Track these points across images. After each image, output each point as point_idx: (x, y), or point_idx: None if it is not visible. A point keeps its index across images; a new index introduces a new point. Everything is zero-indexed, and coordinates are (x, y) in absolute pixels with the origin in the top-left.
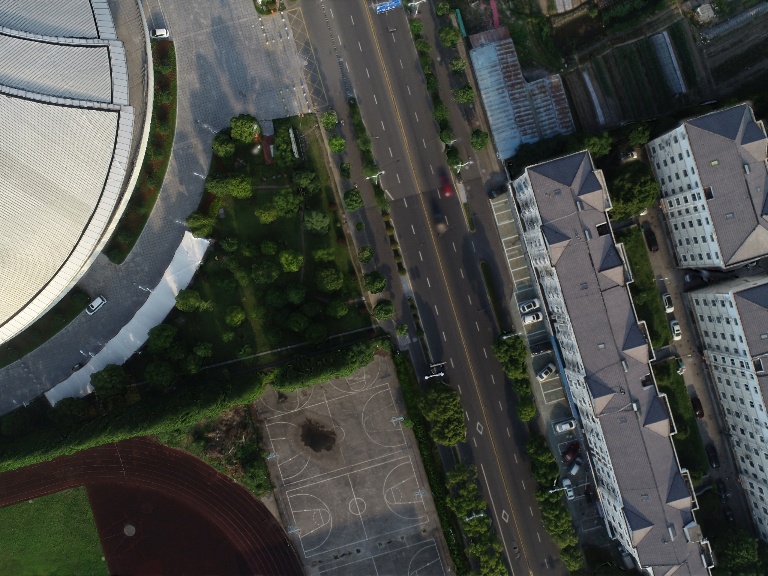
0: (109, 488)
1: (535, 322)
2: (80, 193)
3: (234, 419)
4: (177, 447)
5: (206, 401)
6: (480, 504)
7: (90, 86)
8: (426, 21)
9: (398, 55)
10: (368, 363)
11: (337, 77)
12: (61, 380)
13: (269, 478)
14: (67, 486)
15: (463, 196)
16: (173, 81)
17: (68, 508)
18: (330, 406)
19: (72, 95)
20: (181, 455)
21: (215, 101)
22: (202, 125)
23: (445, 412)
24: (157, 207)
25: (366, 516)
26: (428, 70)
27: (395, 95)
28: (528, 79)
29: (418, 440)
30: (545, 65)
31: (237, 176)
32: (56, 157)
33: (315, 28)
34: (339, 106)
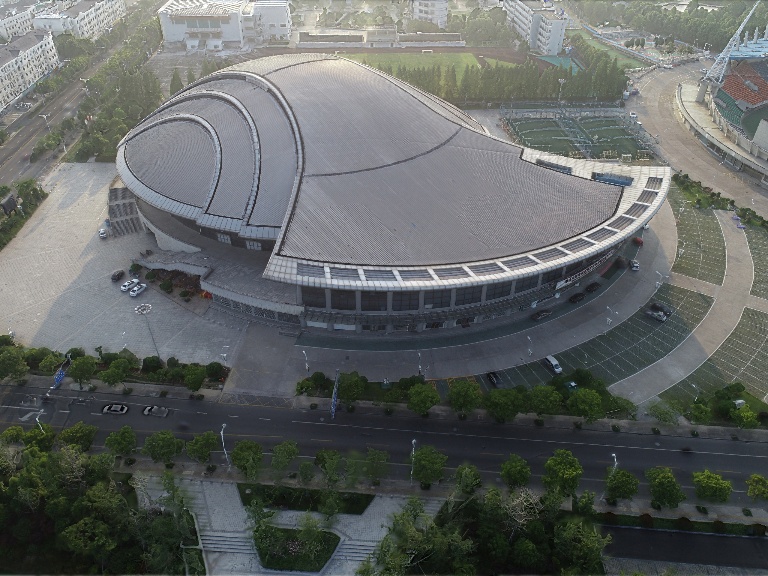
0: None
1: None
2: None
3: None
4: None
5: (192, 81)
6: (103, 66)
7: None
8: None
9: None
10: None
11: None
12: None
13: None
14: None
15: None
16: None
17: None
18: None
19: None
20: None
21: None
22: None
23: None
24: None
25: None
26: None
27: None
28: None
29: None
30: None
31: (119, 130)
32: None
33: None
34: None
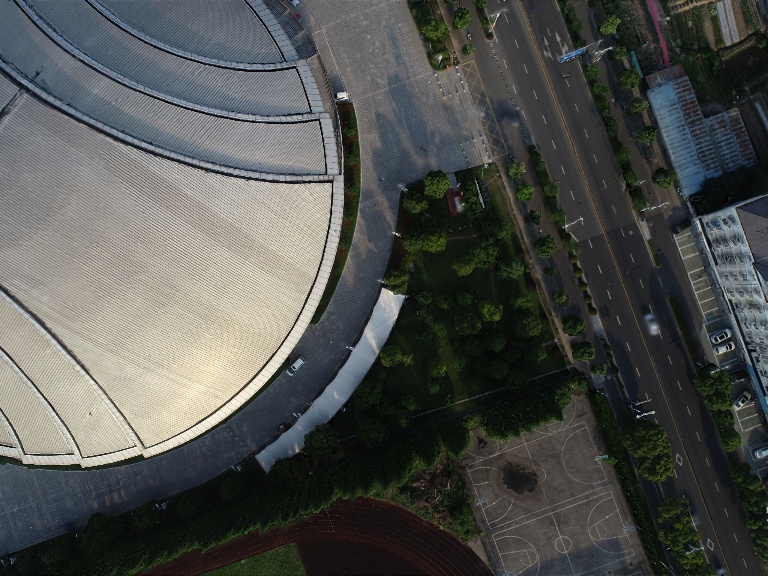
0: (318, 543)
1: (726, 352)
2: (304, 264)
3: (437, 467)
4: (382, 499)
5: (425, 455)
6: (695, 536)
7: (308, 160)
8: (598, 64)
9: (573, 100)
10: (567, 404)
11: (514, 126)
12: (266, 441)
13: (475, 523)
14: (278, 544)
15: (647, 233)
16: (356, 142)
17: (280, 565)
18: (529, 448)
19: (295, 171)
20: (387, 506)
21: (397, 158)
22: (386, 182)
23: (655, 448)
24: (348, 266)
25: (572, 554)
26: (608, 113)
27: (573, 139)
28: (703, 114)
29: (623, 476)
30: (718, 99)
31: (434, 232)
32: (286, 233)
33: (490, 79)
34: (519, 154)
